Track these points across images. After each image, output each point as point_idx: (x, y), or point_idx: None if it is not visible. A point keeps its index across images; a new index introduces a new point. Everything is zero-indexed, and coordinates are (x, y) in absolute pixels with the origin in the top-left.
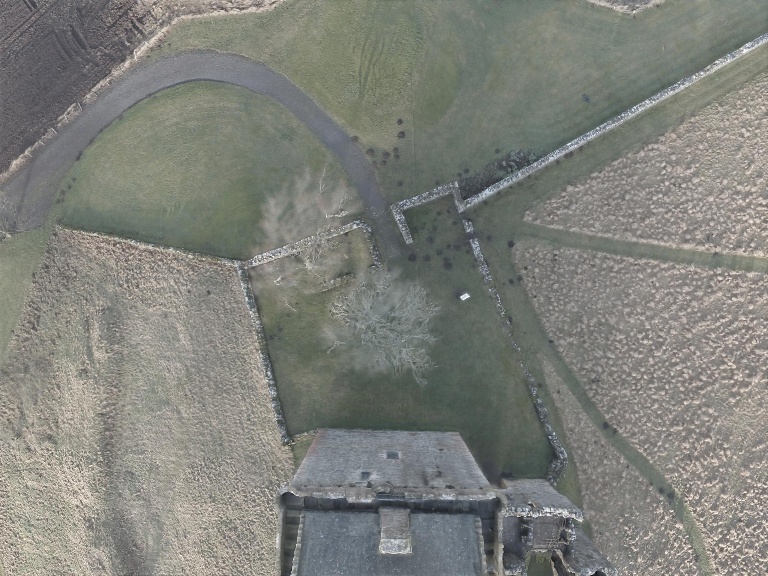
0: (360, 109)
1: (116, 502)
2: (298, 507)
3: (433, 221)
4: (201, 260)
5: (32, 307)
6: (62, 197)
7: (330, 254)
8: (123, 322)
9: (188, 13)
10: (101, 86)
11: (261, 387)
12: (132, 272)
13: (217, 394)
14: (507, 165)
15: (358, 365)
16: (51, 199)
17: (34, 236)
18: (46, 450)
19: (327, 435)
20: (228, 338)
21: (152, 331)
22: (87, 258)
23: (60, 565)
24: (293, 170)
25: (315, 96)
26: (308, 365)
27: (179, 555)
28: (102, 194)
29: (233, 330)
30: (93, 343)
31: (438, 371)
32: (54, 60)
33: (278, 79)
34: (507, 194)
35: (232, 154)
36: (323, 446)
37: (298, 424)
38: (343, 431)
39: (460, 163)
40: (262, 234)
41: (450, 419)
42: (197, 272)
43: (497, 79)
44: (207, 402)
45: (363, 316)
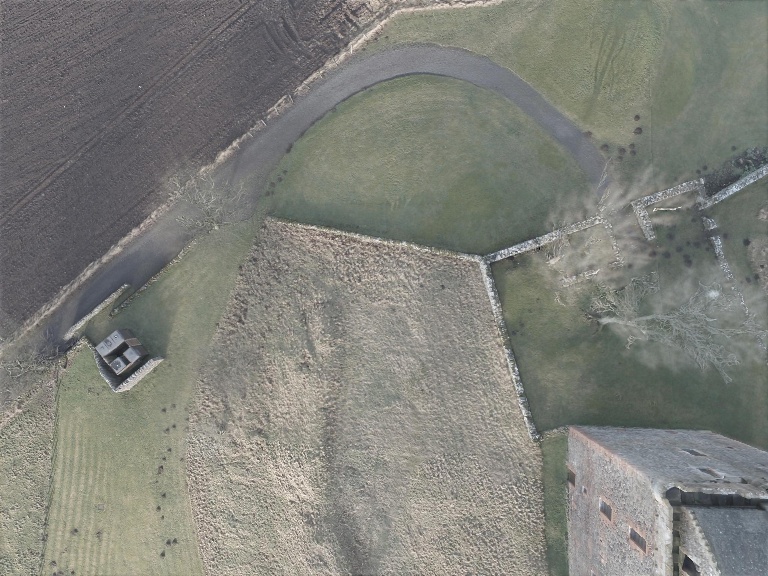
0: (595, 104)
1: (337, 498)
2: (675, 503)
3: (672, 218)
4: (435, 254)
5: (238, 300)
6: (272, 189)
7: (570, 250)
8: (345, 316)
9: (409, 6)
10: (313, 78)
11: (504, 383)
12: (354, 266)
13: (457, 389)
14: (744, 163)
15: (604, 362)
16: (259, 191)
17: (242, 228)
18: (256, 444)
19: (589, 432)
20: (467, 333)
21: (377, 325)
22: (300, 251)
23: (267, 561)
24: (521, 165)
25: (544, 91)
26: (553, 361)
27: (412, 552)
28: (318, 187)
29: (472, 325)
30: (314, 337)
31: (686, 369)
32: (264, 52)
33: (504, 73)
34: (742, 192)
35: (460, 148)
36: (609, 443)
37: (545, 421)
38: (597, 428)
39: (698, 160)
40: (497, 229)
41: (701, 417)
42: (430, 266)
43: (732, 76)
44: (446, 397)
45: (631, 312)
